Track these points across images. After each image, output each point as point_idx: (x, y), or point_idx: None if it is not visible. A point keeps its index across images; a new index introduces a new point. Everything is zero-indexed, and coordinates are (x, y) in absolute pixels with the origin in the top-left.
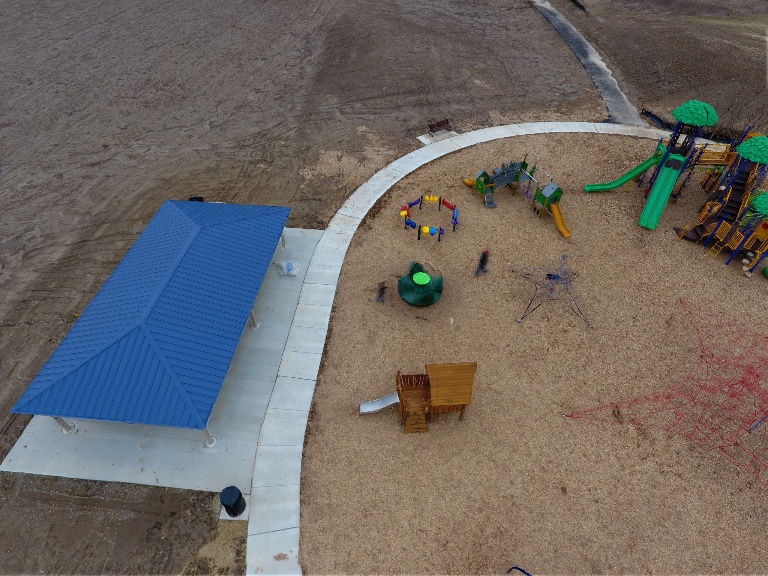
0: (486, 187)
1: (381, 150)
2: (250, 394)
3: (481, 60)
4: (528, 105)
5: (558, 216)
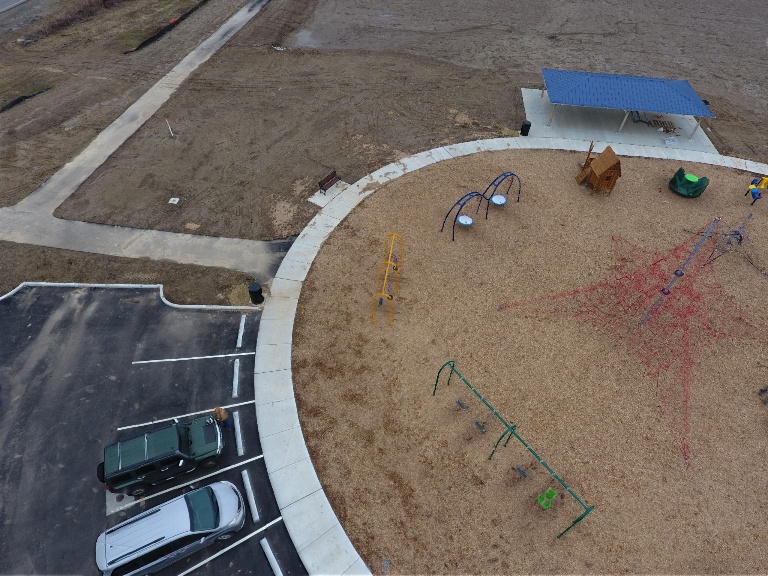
0: None
1: None
2: (576, 134)
3: None
4: None
5: None
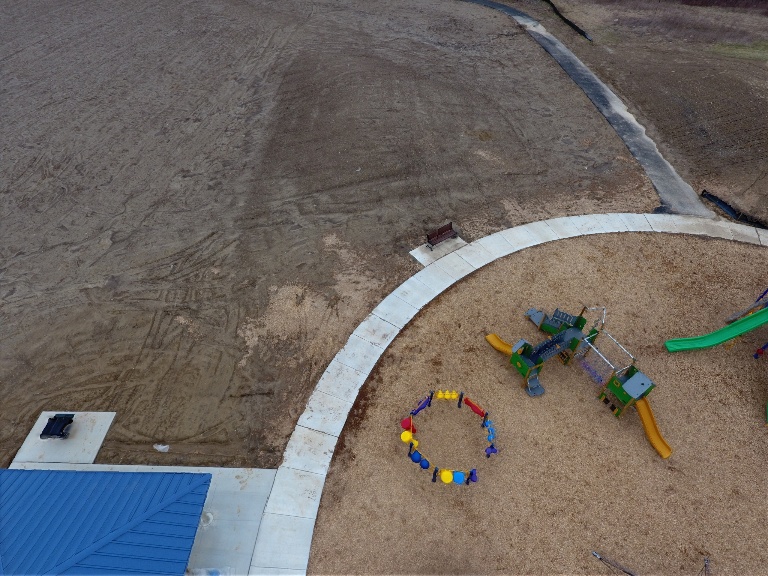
0: (530, 370)
1: (361, 280)
2: None
3: (481, 117)
4: (553, 188)
5: (648, 420)
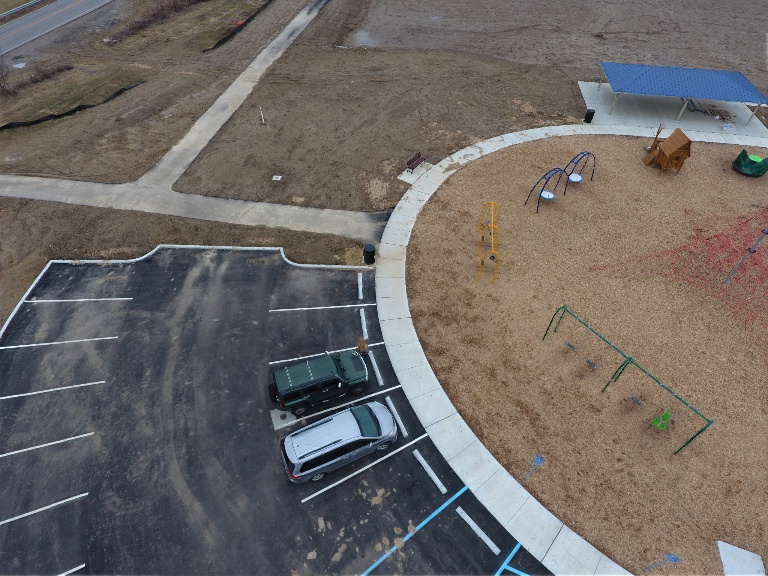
0: None
1: None
2: (637, 122)
3: None
4: None
5: None
